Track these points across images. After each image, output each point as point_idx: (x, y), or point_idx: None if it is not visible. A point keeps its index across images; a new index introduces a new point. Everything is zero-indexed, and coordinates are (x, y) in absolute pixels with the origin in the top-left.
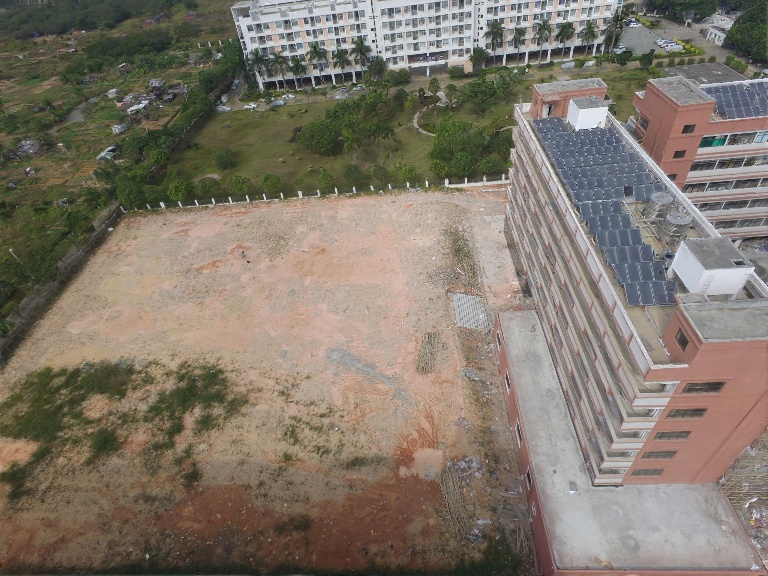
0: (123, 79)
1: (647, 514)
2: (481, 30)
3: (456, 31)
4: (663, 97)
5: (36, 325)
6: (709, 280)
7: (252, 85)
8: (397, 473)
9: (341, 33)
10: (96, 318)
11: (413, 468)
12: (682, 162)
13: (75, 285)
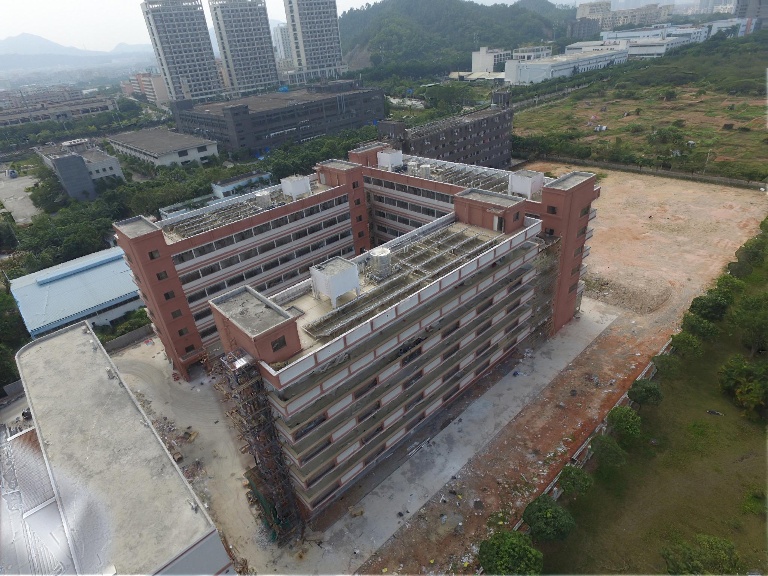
0: None
1: None
2: None
3: None
4: None
5: (650, 175)
6: None
7: None
8: None
9: None
10: None
11: None
12: None
13: (684, 181)
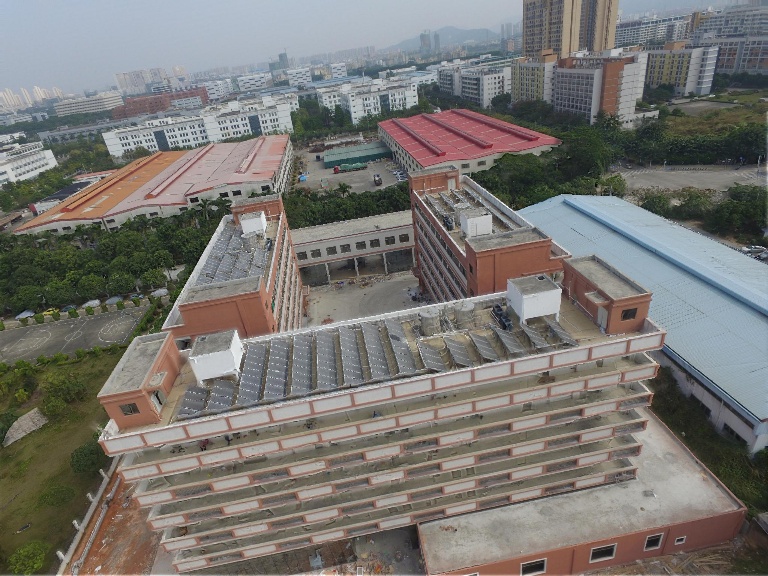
0: None
1: None
2: None
3: None
4: (223, 301)
5: None
6: None
7: None
8: None
9: None
10: None
11: None
12: None
13: None
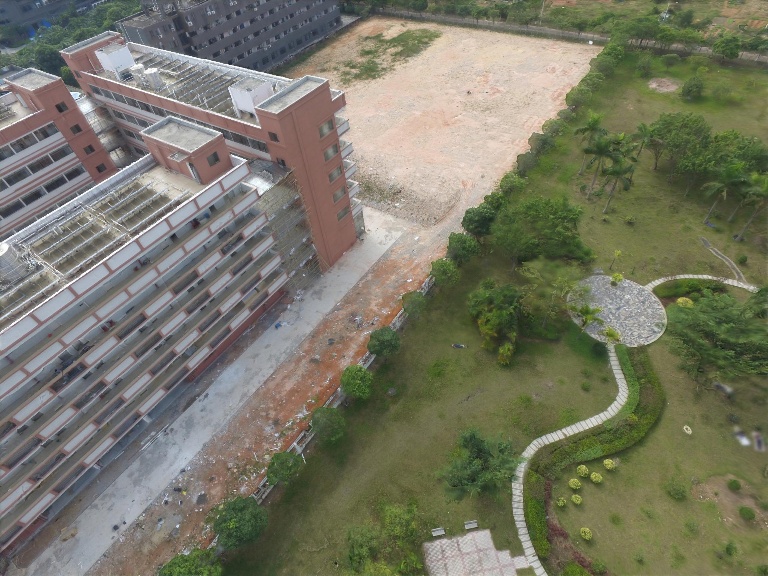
0: None
1: None
2: None
3: None
4: None
5: (486, 30)
6: None
7: None
8: None
9: None
10: (470, 45)
11: None
12: None
13: (518, 37)
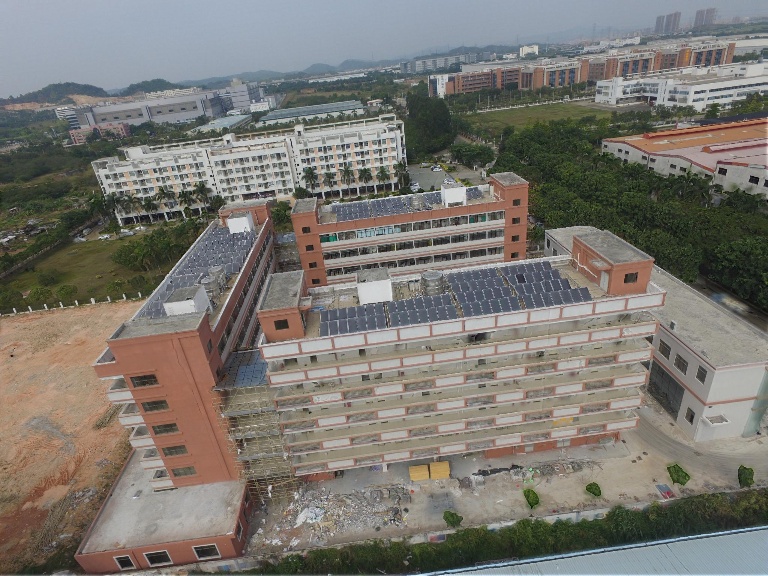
0: (8, 220)
1: (180, 506)
2: (300, 175)
3: (278, 176)
4: None
5: None
6: (170, 311)
7: (112, 221)
8: (20, 507)
9: (186, 179)
10: None
11: (37, 502)
12: (314, 253)
13: None
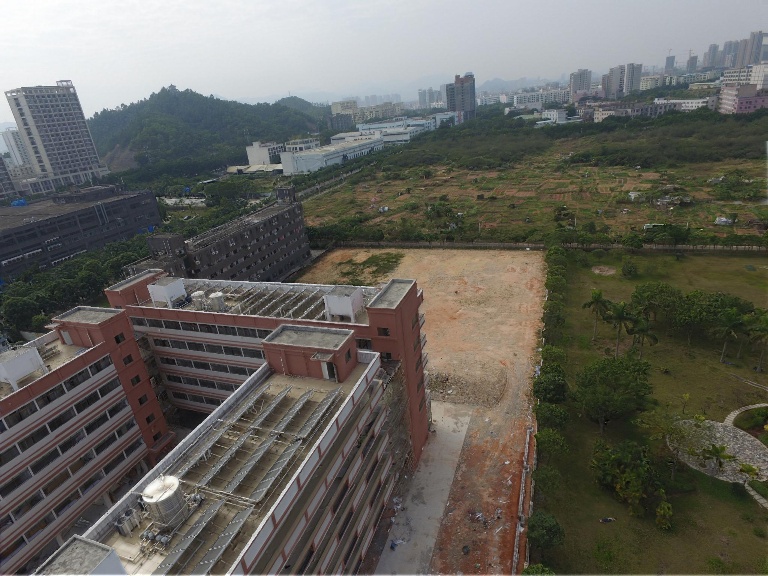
0: None
1: None
2: None
3: None
4: None
5: (439, 249)
6: None
7: None
8: None
9: None
10: (433, 260)
11: None
12: None
13: None
